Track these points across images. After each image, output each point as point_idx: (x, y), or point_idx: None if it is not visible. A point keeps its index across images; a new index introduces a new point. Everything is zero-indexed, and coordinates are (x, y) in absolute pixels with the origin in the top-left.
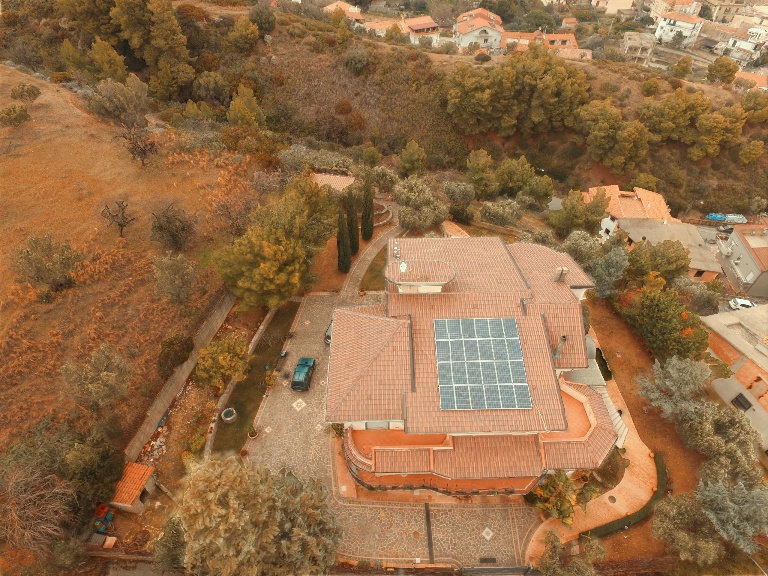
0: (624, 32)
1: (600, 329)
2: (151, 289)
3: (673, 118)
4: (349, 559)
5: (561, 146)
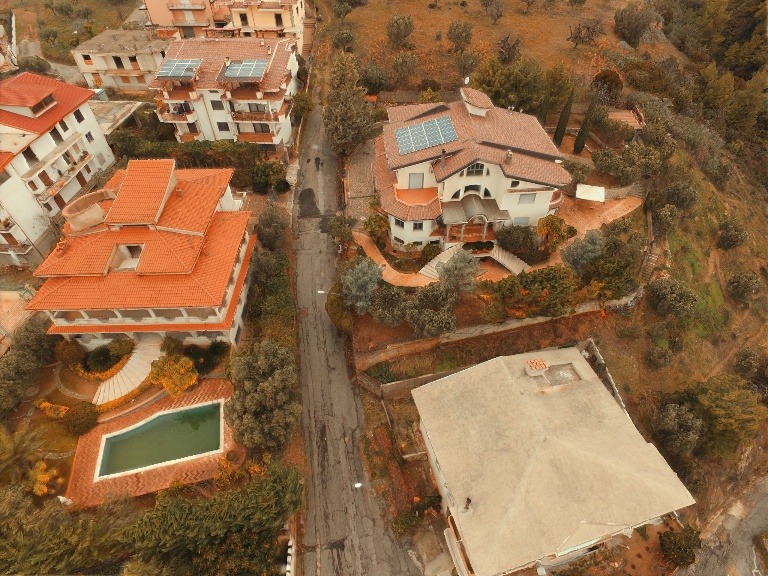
0: None
1: None
2: None
3: None
4: None
5: None
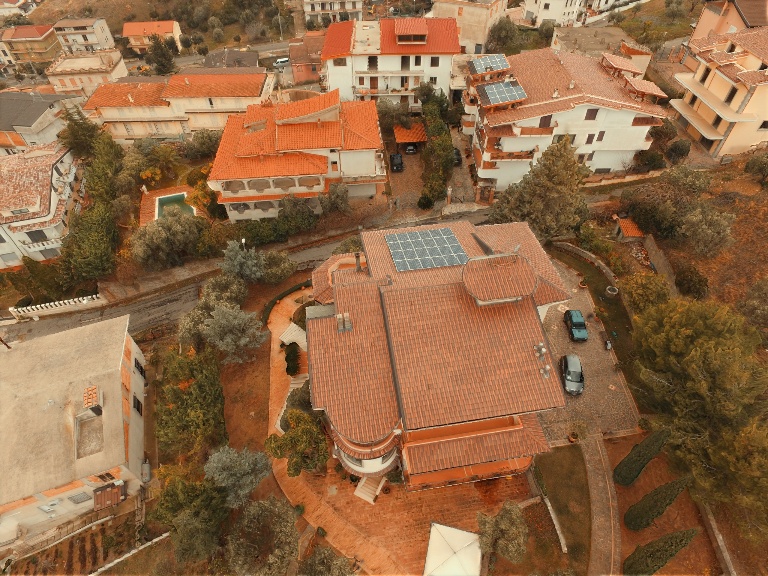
0: None
1: (258, 451)
2: None
3: None
4: None
5: None
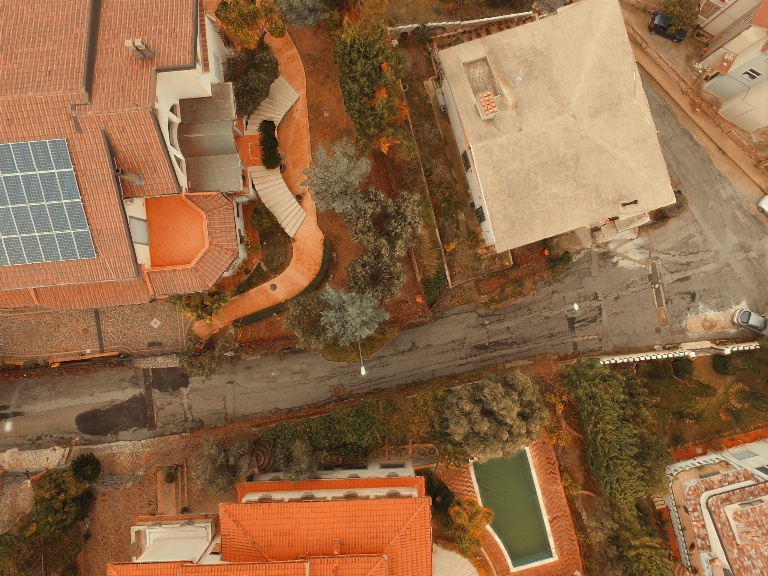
0: None
1: (314, 72)
2: None
3: None
4: (15, 361)
5: None
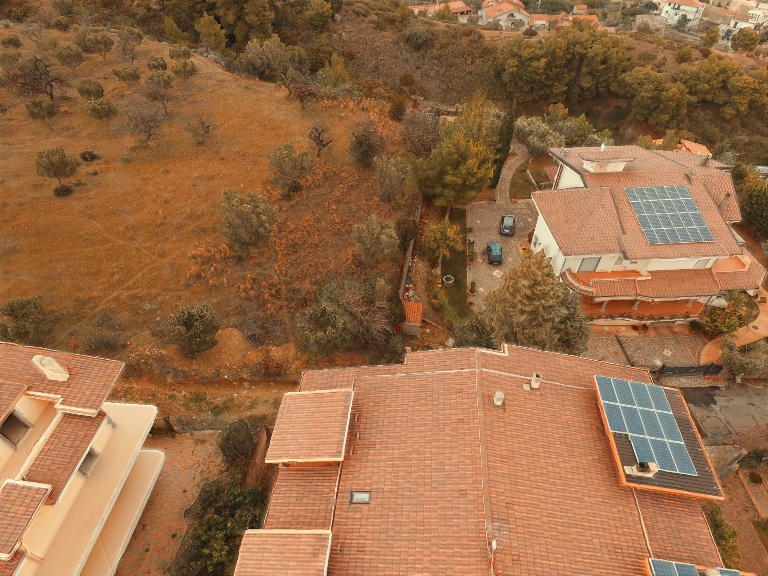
0: (631, 17)
1: None
2: (361, 192)
3: (708, 81)
4: None
5: (605, 110)
